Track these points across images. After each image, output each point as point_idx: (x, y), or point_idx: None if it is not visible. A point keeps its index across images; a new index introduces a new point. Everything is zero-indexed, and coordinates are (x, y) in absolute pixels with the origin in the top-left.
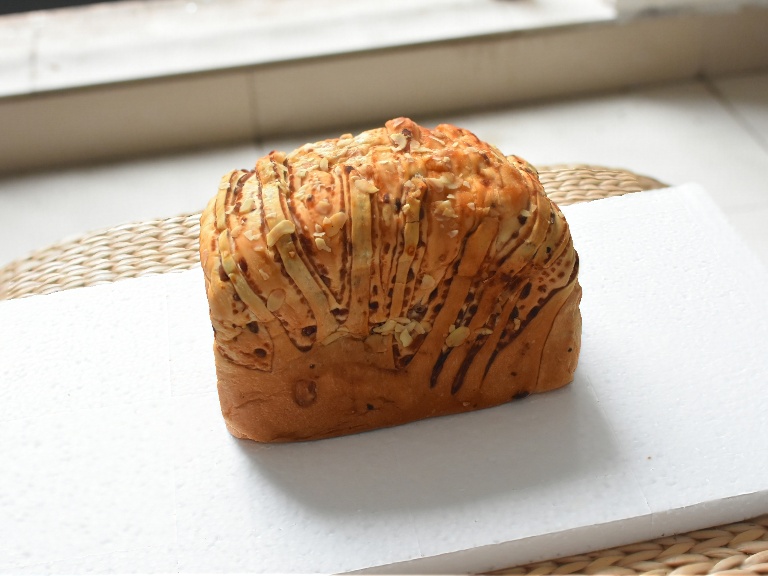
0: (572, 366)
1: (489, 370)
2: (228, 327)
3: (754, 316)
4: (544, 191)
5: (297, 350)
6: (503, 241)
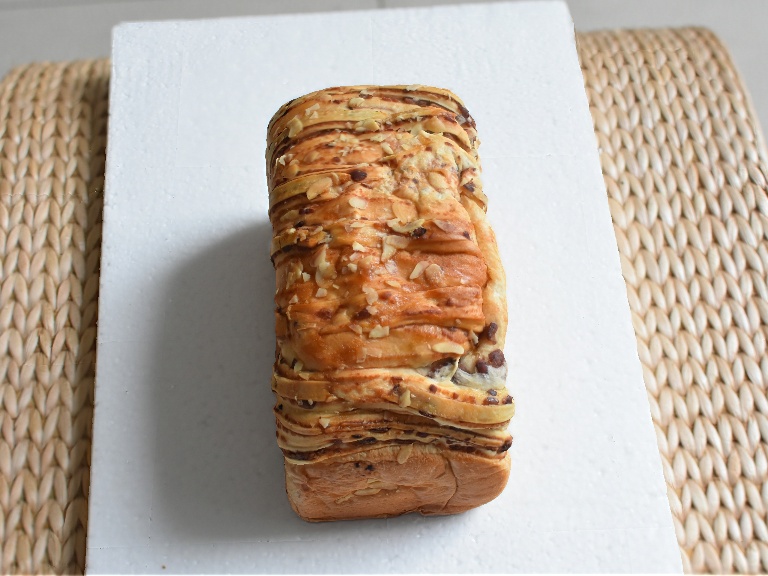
0: None
1: None
2: None
3: None
4: (348, 398)
5: None
6: None
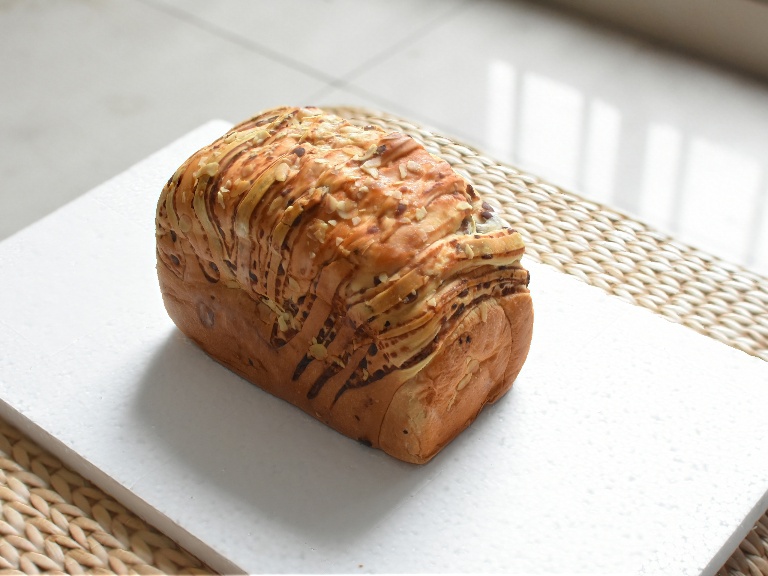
0: (411, 449)
1: (338, 399)
2: (157, 224)
3: (649, 543)
4: (436, 272)
5: (204, 276)
6: (353, 290)
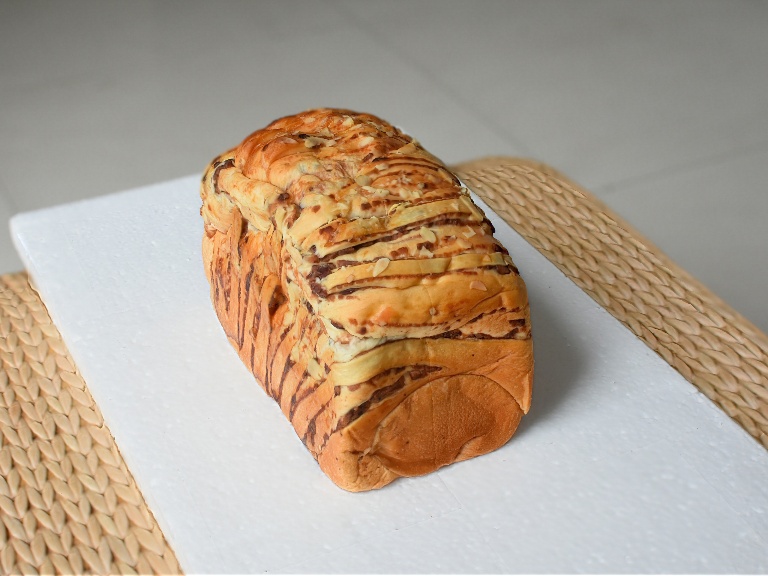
0: None
1: None
2: None
3: None
4: None
5: None
6: None
